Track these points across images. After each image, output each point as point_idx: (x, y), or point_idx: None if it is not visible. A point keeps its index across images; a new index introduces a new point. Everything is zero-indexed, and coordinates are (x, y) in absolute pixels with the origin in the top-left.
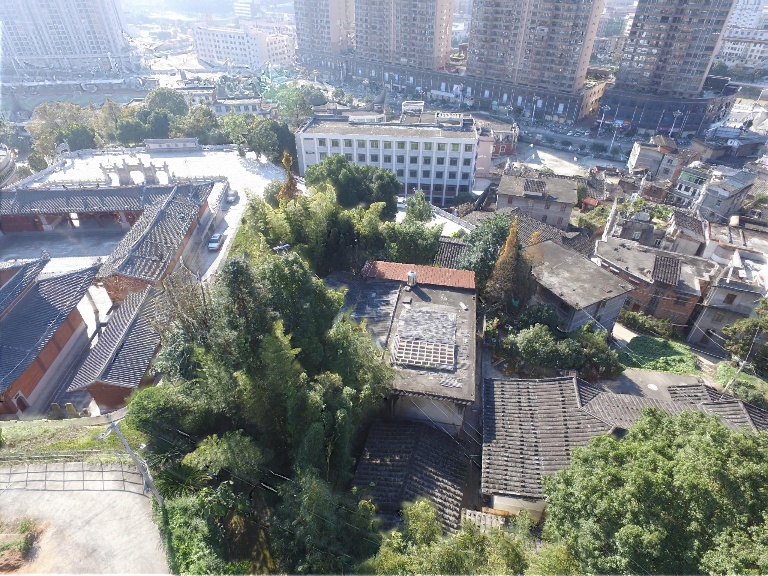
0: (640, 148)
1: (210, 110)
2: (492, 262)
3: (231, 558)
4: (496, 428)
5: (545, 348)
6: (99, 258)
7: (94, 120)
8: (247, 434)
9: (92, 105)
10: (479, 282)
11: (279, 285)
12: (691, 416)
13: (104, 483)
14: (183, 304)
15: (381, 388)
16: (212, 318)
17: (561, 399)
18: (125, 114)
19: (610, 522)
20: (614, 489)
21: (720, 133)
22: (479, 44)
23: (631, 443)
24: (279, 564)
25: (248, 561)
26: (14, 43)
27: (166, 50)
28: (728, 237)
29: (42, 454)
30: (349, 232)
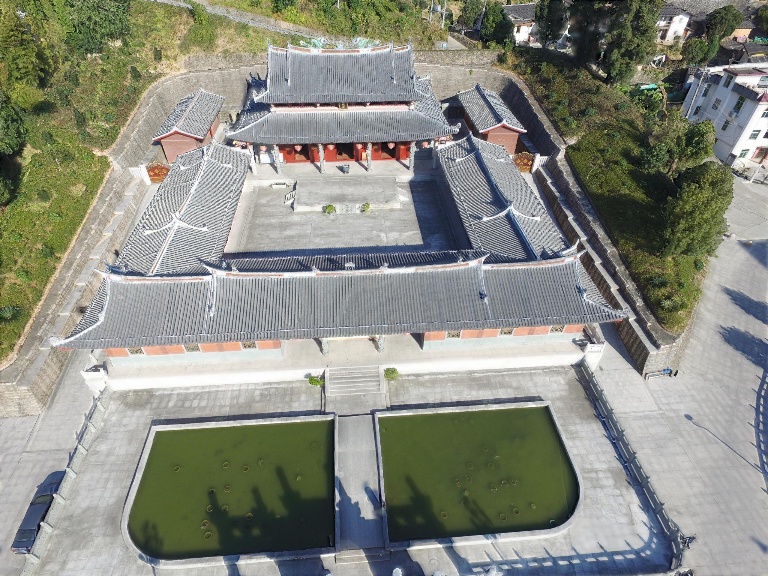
0: None
1: None
2: None
3: None
4: None
5: None
6: (225, 130)
7: None
8: None
9: None
10: None
11: None
12: None
13: None
14: None
15: None
16: None
17: None
18: None
19: None
20: None
21: None
22: None
23: None
24: None
25: None
26: None
27: None
28: None
29: (168, 4)
30: None
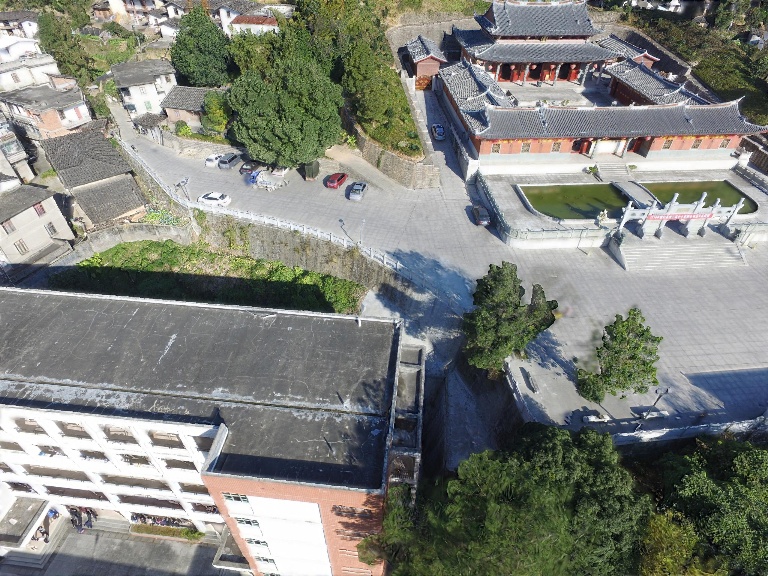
0: None
1: None
2: None
3: None
4: None
5: None
6: None
7: None
8: None
9: None
10: None
11: None
12: None
13: None
14: None
15: None
16: None
17: None
18: None
19: None
20: None
21: None
22: None
23: None
24: None
25: None
26: None
27: None
28: None
29: None
30: None
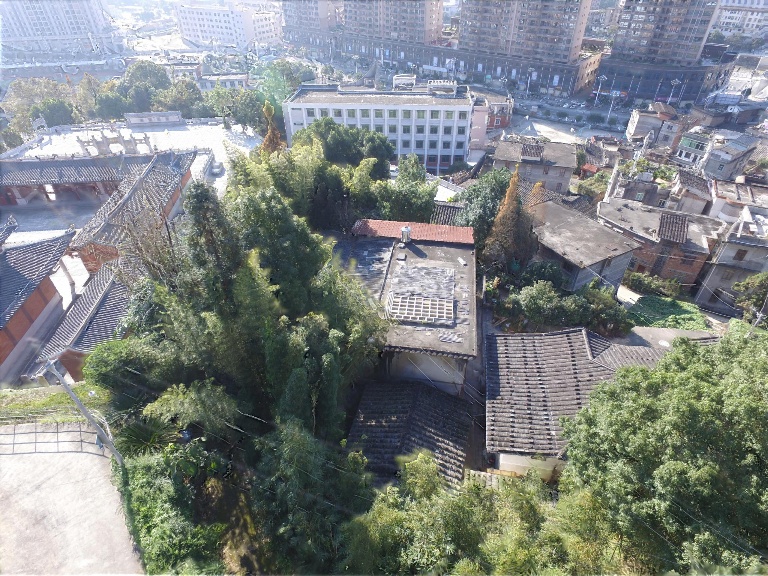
0: (639, 115)
1: (193, 83)
2: (491, 218)
3: (206, 524)
4: (500, 384)
5: (550, 304)
6: (72, 225)
7: (72, 96)
8: None
9: (69, 80)
10: (477, 241)
11: (255, 222)
12: None
13: (59, 444)
14: (148, 247)
15: (374, 341)
16: (178, 258)
17: (570, 352)
18: (105, 89)
19: (645, 461)
20: (650, 422)
21: (720, 100)
22: (471, 15)
23: (665, 373)
24: (261, 529)
25: (226, 527)
26: None
27: (149, 31)
28: (736, 194)
29: None
30: (338, 189)
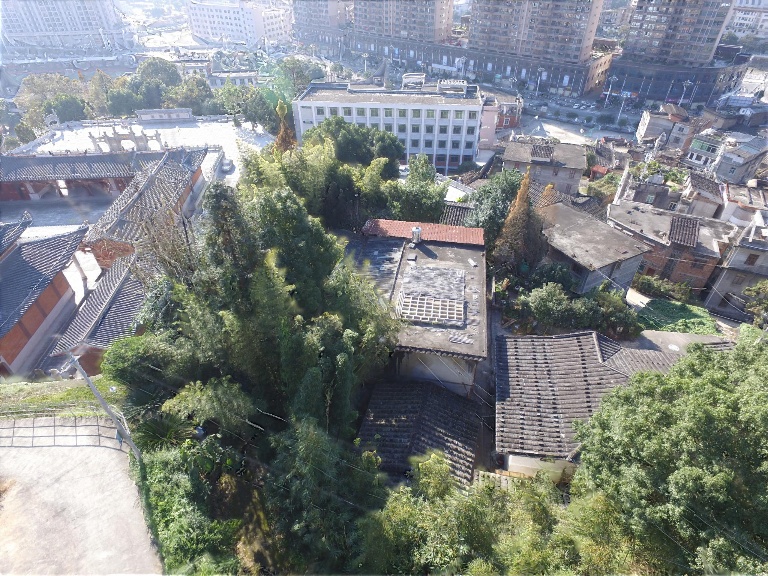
0: (650, 116)
1: (204, 80)
2: (501, 219)
3: None
4: (510, 386)
5: (559, 307)
6: (85, 221)
7: (84, 92)
8: (235, 381)
9: (81, 76)
10: (487, 242)
11: (271, 222)
12: (747, 350)
13: (77, 438)
14: (164, 245)
15: (385, 341)
16: (195, 256)
17: (580, 355)
18: (116, 86)
19: (660, 466)
20: (665, 427)
21: (732, 102)
22: (482, 14)
23: None
24: (274, 525)
25: None
26: (3, 20)
27: (160, 27)
28: (748, 198)
29: (10, 409)
30: (349, 188)
